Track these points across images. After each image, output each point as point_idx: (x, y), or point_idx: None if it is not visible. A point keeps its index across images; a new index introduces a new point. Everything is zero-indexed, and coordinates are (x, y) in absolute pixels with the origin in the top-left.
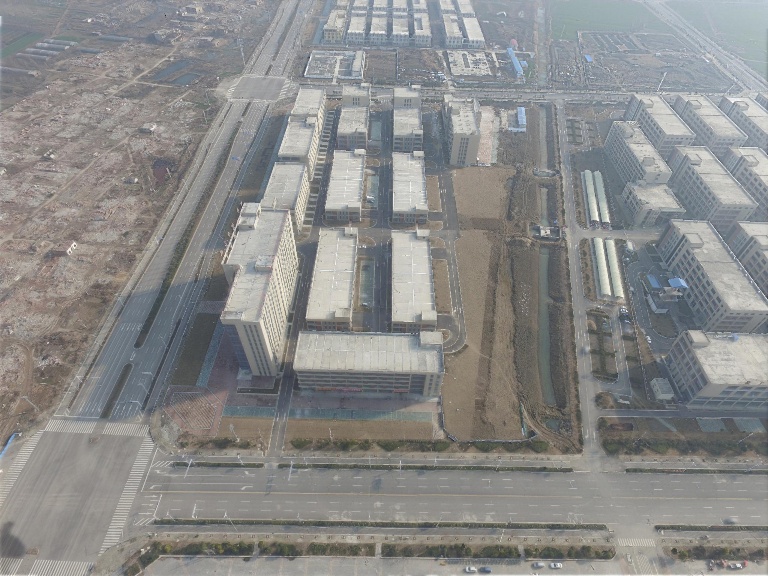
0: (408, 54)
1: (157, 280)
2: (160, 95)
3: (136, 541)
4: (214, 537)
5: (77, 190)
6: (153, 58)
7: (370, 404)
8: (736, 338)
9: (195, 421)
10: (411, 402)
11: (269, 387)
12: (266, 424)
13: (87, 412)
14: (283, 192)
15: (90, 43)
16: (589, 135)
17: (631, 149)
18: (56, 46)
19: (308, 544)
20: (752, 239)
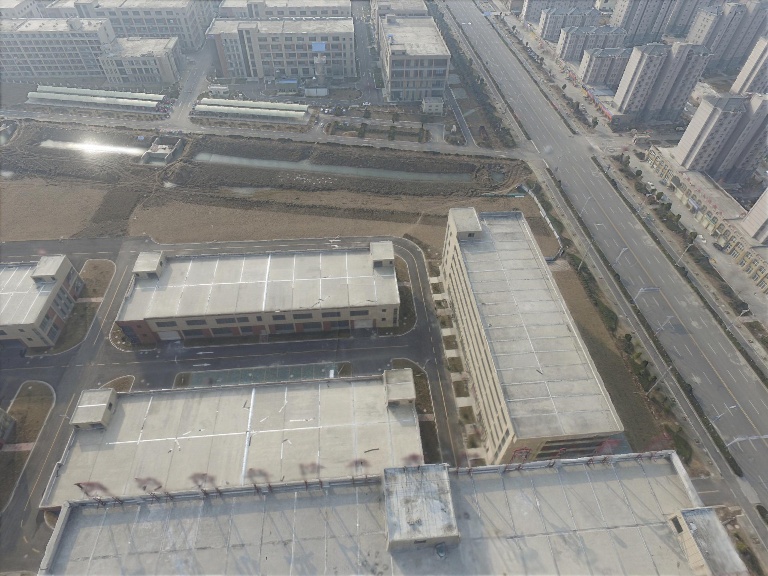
0: None
1: None
2: None
3: None
4: None
5: None
6: None
7: None
8: None
9: None
10: None
11: None
12: None
13: None
14: None
15: None
16: None
17: (31, 31)
18: None
19: None
20: (250, 6)
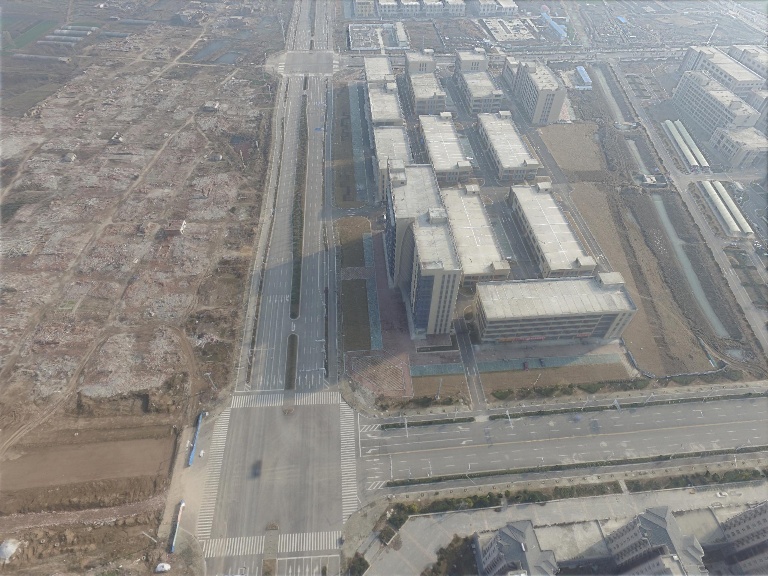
0: (445, 24)
1: (286, 252)
2: (208, 74)
3: (376, 505)
4: (455, 492)
5: (162, 171)
6: (186, 39)
7: (554, 351)
8: None
9: (386, 383)
10: (594, 346)
11: (447, 344)
12: (460, 379)
13: (269, 385)
14: (394, 155)
15: (111, 28)
16: (653, 89)
17: (713, 95)
18: (77, 32)
19: (552, 489)
20: None
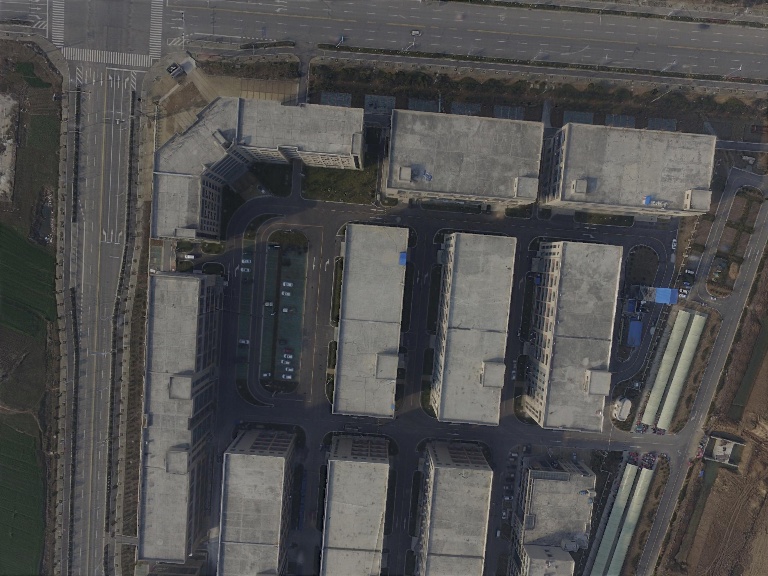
0: None
1: None
2: None
3: None
4: None
5: None
6: None
7: None
8: None
9: None
10: None
11: None
12: None
13: None
14: None
15: None
16: None
17: None
18: None
19: None
20: None
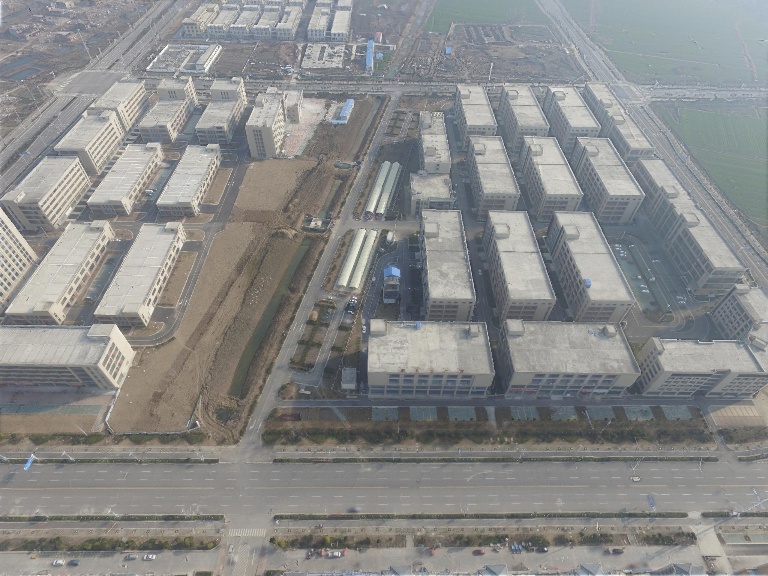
0: (267, 47)
1: None
2: None
3: None
4: None
5: None
6: None
7: (42, 398)
8: (418, 326)
9: None
10: (86, 395)
11: None
12: None
13: None
14: (38, 186)
15: None
16: (409, 126)
17: (422, 139)
18: None
19: None
20: (493, 228)
